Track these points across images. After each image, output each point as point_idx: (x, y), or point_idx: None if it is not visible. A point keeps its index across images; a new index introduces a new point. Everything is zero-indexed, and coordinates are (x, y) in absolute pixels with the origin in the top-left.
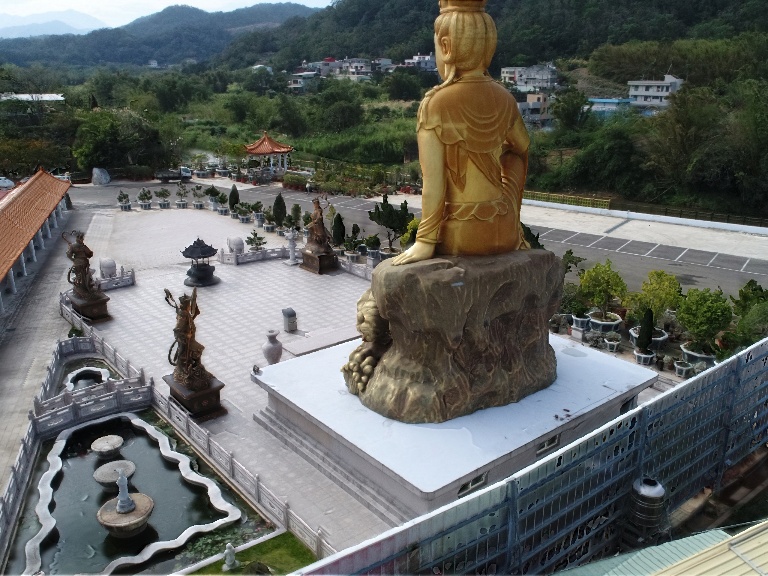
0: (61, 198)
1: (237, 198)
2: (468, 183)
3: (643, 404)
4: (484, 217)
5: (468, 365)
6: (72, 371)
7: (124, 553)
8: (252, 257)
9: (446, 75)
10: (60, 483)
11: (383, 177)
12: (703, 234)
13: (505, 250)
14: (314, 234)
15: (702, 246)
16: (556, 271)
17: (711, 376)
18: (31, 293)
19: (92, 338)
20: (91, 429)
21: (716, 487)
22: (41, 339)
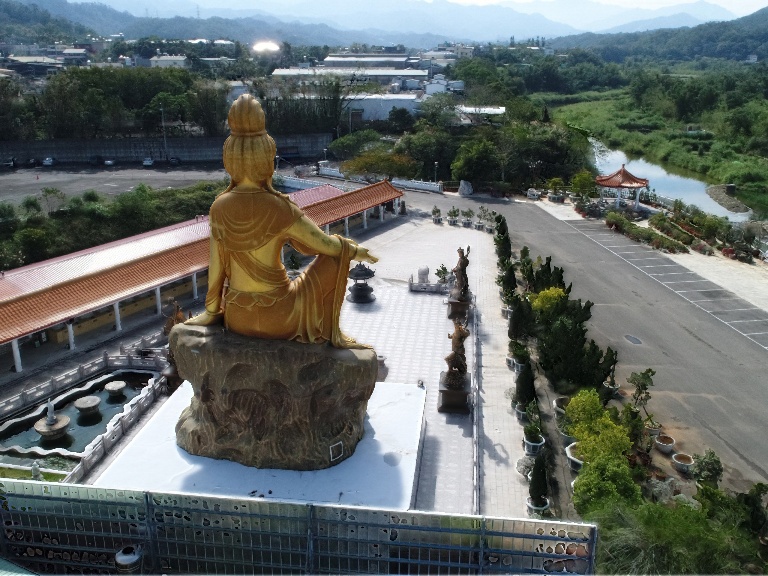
0: (371, 206)
1: (505, 230)
2: (233, 274)
3: None
4: (242, 304)
5: (222, 420)
6: None
7: None
8: (426, 288)
9: None
10: None
11: (716, 232)
12: None
13: (270, 337)
14: None
15: None
16: (328, 370)
17: (265, 507)
18: None
19: None
20: (132, 375)
21: None
22: None
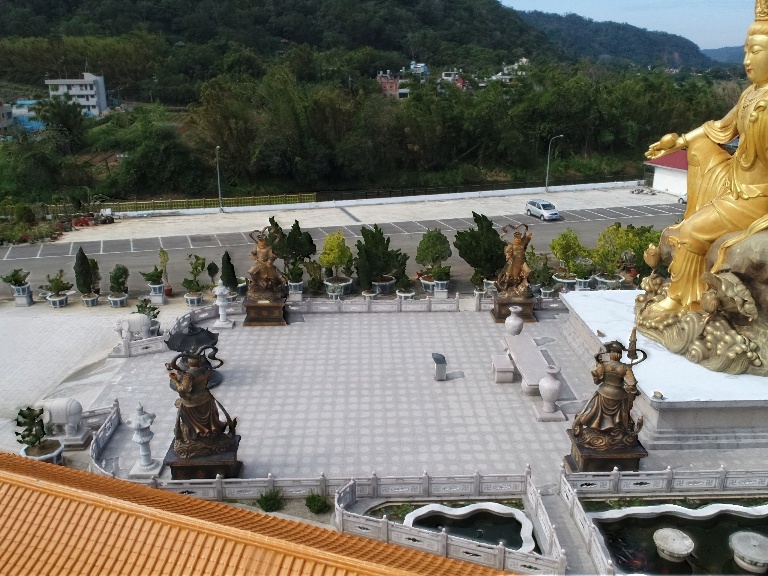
0: None
1: None
2: None
3: None
4: None
5: None
6: None
7: None
8: None
9: None
10: None
11: None
12: (414, 208)
13: None
14: (261, 279)
15: (438, 216)
16: None
17: None
18: None
19: (355, 483)
20: None
21: None
22: None
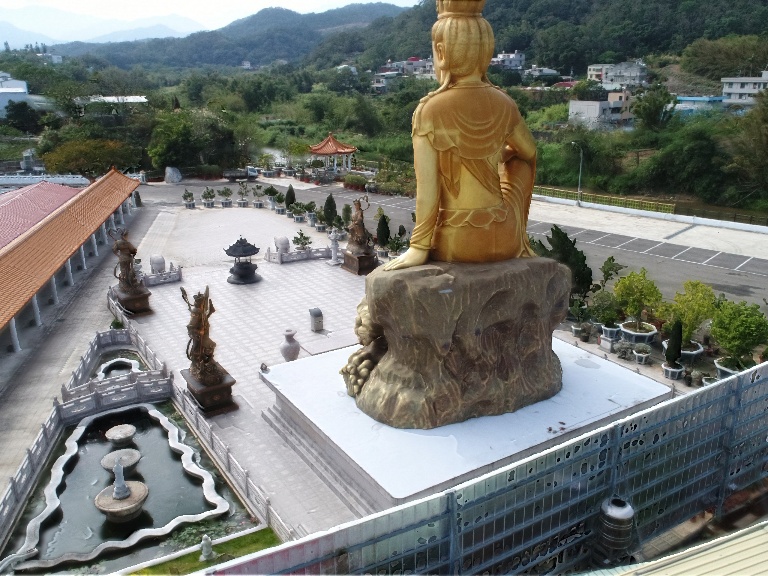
0: (128, 196)
1: (293, 198)
2: (462, 190)
3: (616, 422)
4: (479, 224)
5: (461, 373)
6: (106, 361)
7: (117, 537)
8: (296, 256)
9: (442, 81)
10: (74, 467)
11: None
12: None
13: (503, 258)
14: (355, 235)
15: None
16: (561, 280)
17: (704, 395)
18: (86, 286)
19: (128, 331)
20: (111, 417)
21: (717, 512)
22: (85, 330)
